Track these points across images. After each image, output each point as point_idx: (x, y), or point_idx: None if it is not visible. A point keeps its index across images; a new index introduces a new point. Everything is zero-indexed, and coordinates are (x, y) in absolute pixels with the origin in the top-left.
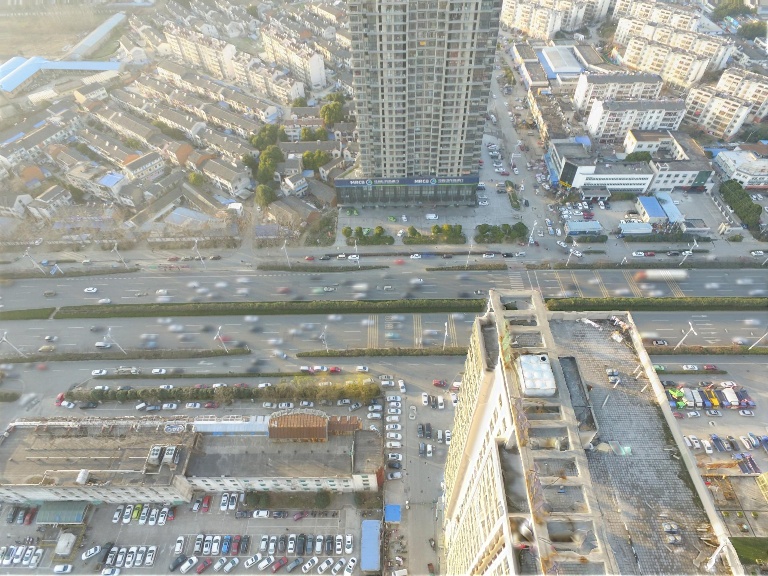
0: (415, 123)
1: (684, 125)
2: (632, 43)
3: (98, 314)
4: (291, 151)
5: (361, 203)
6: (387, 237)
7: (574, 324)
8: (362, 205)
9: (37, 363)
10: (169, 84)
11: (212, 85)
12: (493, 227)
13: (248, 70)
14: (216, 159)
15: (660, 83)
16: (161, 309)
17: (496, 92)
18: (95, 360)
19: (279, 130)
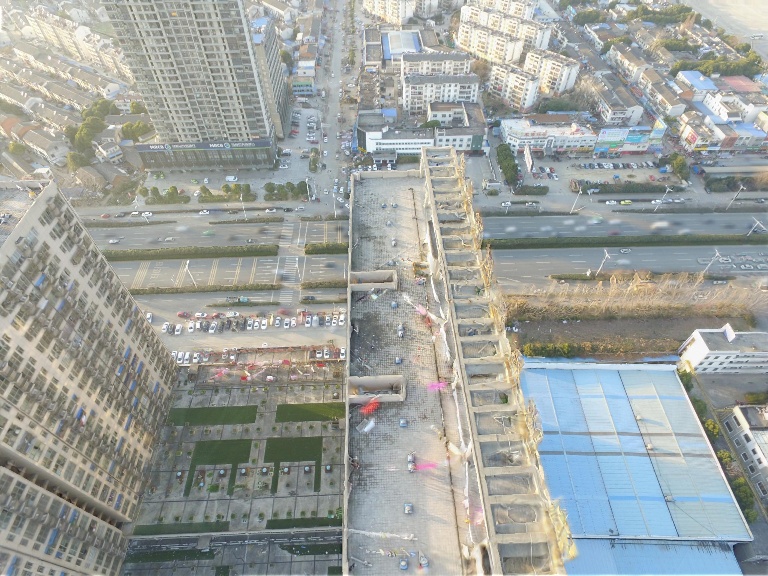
0: (194, 90)
1: (492, 99)
2: (461, 27)
3: None
4: (116, 123)
5: (168, 168)
6: (184, 197)
7: (14, 191)
8: (169, 169)
9: None
10: (24, 64)
11: (61, 64)
12: (278, 185)
13: (98, 50)
14: (37, 130)
15: (467, 61)
16: None
17: (336, 72)
18: None
19: (111, 104)
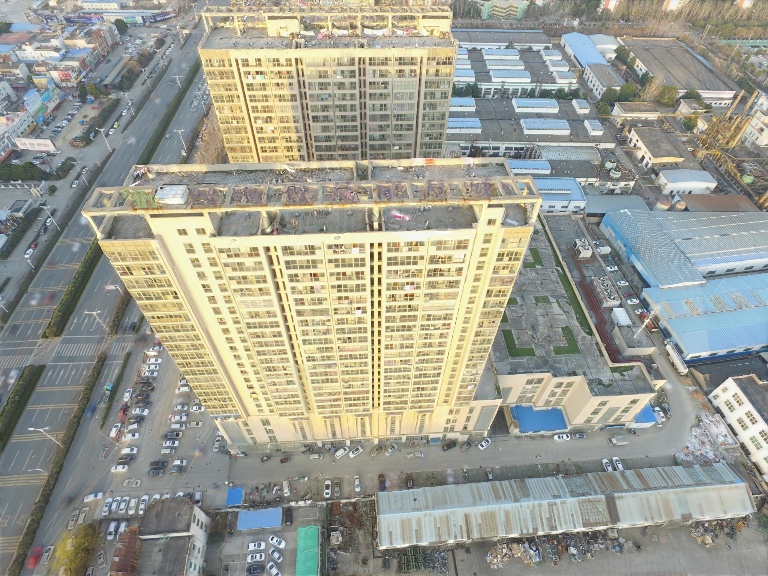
0: None
1: None
2: None
3: None
4: None
5: None
6: None
7: None
8: None
9: None
10: None
11: None
12: None
13: None
14: None
15: None
16: None
17: None
18: None
19: None
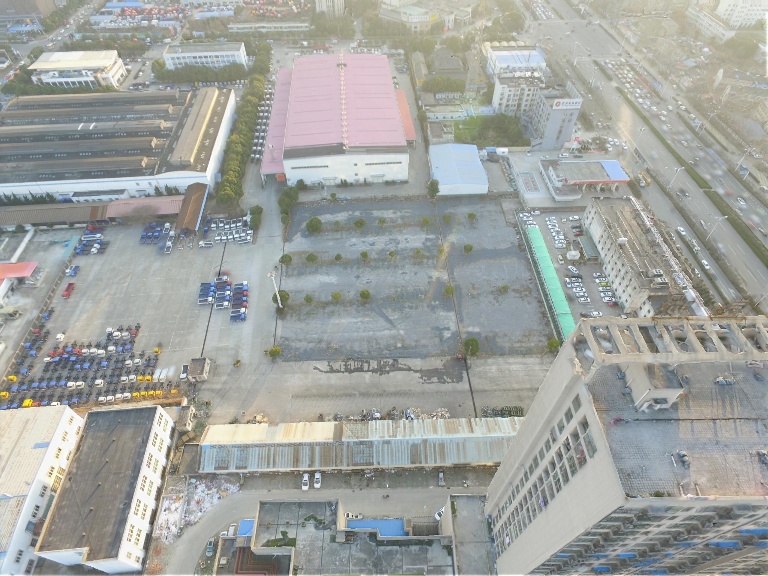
0: None
1: None
2: None
3: (726, 212)
4: None
5: None
6: None
7: None
8: None
9: (666, 197)
10: None
11: None
12: None
13: None
14: None
15: None
16: (760, 248)
17: None
18: (689, 225)
19: None
